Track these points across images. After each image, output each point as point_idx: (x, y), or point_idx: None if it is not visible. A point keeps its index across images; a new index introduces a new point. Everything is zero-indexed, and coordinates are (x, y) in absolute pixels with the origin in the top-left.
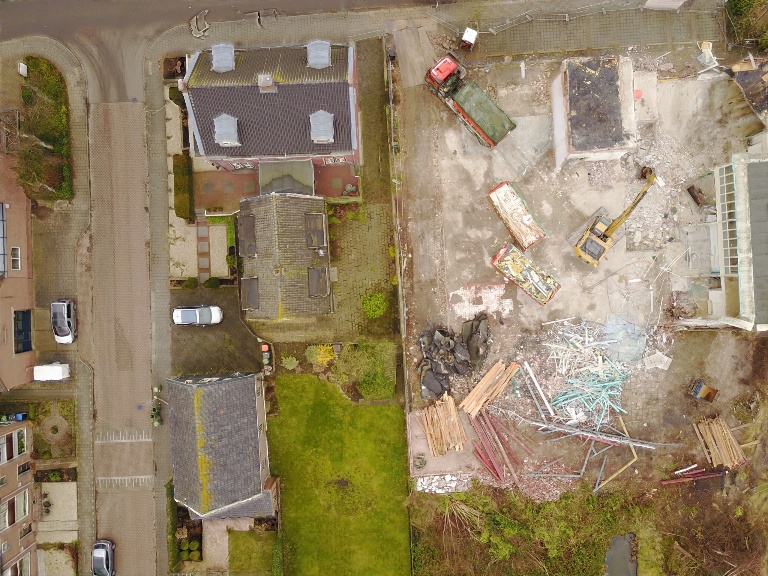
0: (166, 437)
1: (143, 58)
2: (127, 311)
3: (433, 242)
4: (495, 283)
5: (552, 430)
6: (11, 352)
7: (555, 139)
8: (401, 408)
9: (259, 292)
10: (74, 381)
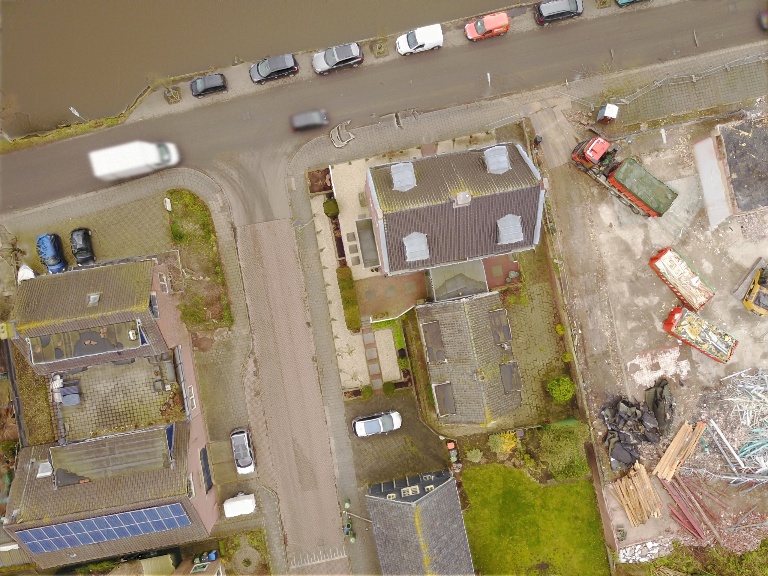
0: (361, 551)
1: (285, 175)
2: (303, 430)
3: (600, 315)
4: (669, 347)
5: (744, 481)
6: (205, 495)
7: (706, 198)
8: (590, 482)
9: (455, 397)
10: (260, 509)
